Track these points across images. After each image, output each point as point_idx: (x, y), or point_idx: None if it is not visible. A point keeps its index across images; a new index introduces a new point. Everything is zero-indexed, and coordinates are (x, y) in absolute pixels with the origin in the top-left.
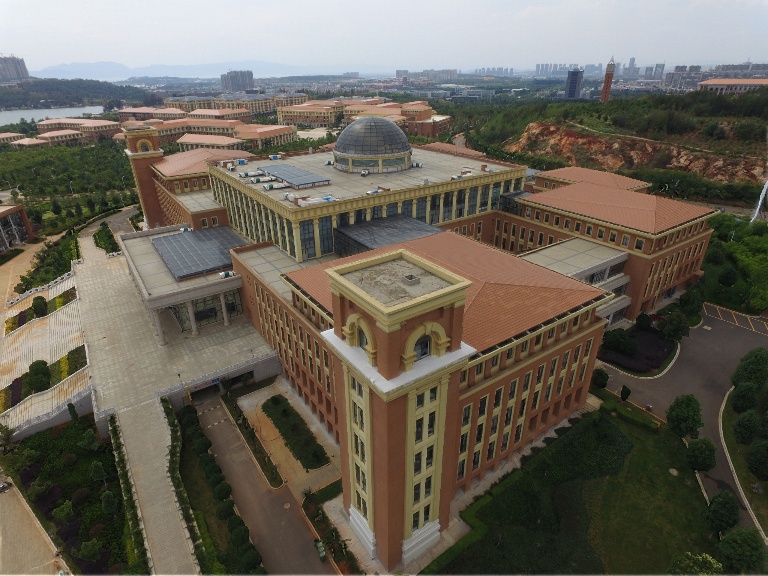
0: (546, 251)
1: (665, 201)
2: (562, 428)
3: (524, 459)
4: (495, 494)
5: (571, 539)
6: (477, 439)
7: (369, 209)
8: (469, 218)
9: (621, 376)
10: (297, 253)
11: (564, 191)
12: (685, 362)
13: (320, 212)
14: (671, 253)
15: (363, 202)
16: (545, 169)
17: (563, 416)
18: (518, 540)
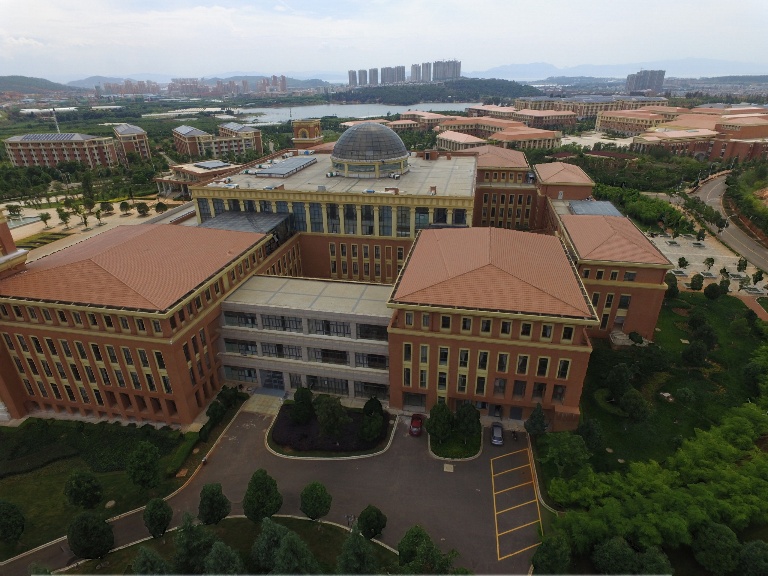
0: (339, 285)
1: (497, 274)
2: (150, 426)
3: (101, 422)
4: (53, 423)
5: (1, 467)
6: (51, 373)
7: (258, 202)
8: (381, 239)
9: (259, 431)
10: (198, 222)
11: (456, 233)
12: (332, 468)
13: (213, 194)
14: (452, 344)
15: (251, 194)
16: (762, 227)
17: (159, 418)
18: (2, 446)
